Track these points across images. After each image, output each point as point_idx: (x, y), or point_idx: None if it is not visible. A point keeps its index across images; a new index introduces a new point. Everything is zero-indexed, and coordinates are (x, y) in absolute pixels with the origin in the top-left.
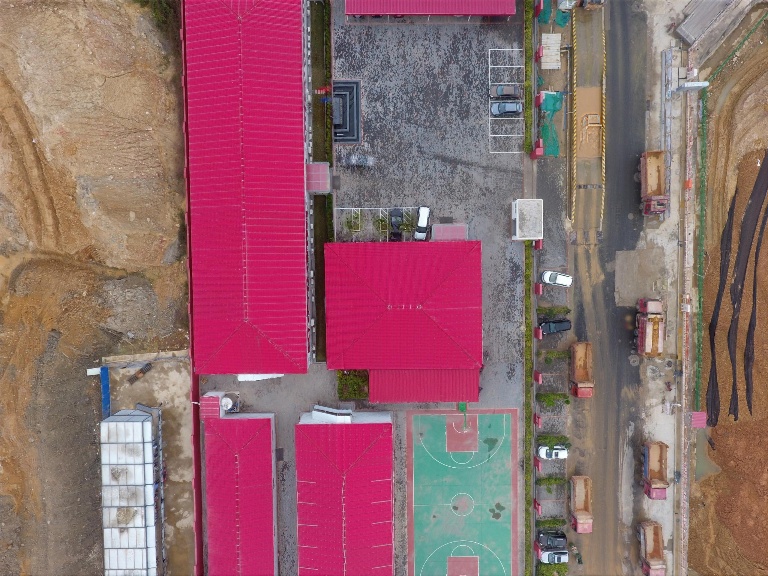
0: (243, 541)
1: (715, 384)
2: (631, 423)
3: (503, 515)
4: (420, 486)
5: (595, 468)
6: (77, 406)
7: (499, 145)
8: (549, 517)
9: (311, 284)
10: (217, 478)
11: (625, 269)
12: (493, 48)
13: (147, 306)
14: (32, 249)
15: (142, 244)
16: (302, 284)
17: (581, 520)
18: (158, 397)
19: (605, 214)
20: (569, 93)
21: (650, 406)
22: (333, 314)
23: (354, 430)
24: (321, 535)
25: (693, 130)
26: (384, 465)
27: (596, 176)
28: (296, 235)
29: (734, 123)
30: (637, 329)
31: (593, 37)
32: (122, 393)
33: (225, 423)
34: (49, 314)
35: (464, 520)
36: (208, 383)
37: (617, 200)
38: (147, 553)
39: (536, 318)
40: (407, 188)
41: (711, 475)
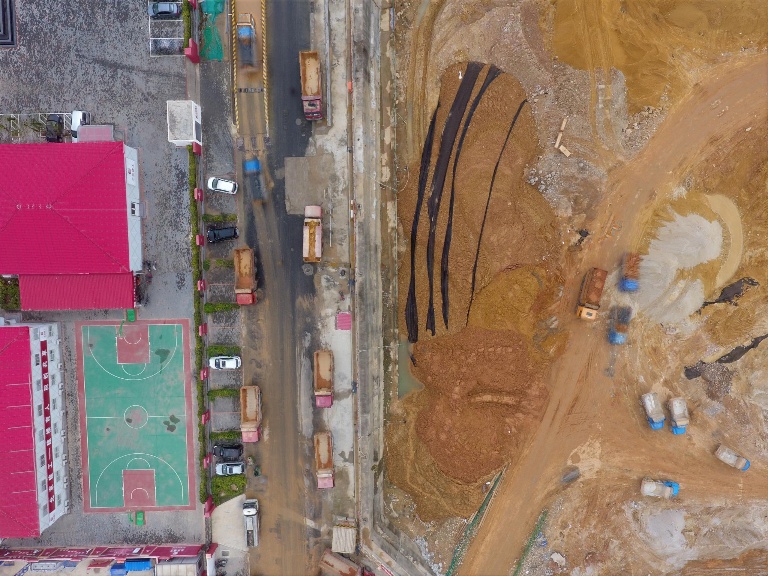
0: None
1: (413, 299)
2: (307, 334)
3: (178, 427)
4: (92, 398)
5: (272, 380)
6: None
7: (160, 48)
8: (227, 429)
9: None
10: None
11: (295, 176)
12: None
13: None
14: None
15: None
16: None
17: (244, 428)
18: None
19: (272, 119)
20: None
21: (326, 316)
22: None
23: None
24: None
25: (359, 33)
26: (21, 369)
27: (257, 79)
28: None
29: (432, 34)
30: None
31: None
32: None
33: None
34: None
35: (138, 433)
36: None
37: (284, 105)
38: None
39: (203, 226)
40: (67, 93)
41: (415, 392)
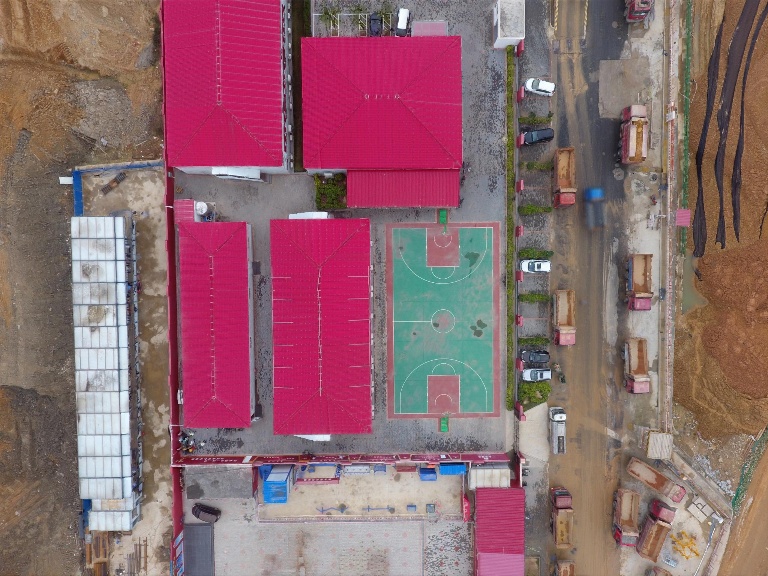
0: (218, 346)
1: (702, 212)
2: (615, 239)
3: (485, 332)
4: (400, 302)
5: (579, 286)
6: (49, 213)
7: None
8: (532, 336)
9: (289, 91)
10: (191, 282)
11: (609, 79)
12: None
13: (121, 110)
14: (3, 48)
15: (116, 45)
16: (277, 73)
17: (564, 330)
18: (132, 208)
19: (589, 22)
20: None
21: (635, 221)
22: (310, 110)
23: (331, 225)
24: (296, 332)
25: None
26: (361, 261)
27: None
28: (271, 21)
29: None
30: (621, 139)
31: None
32: (96, 204)
33: (200, 226)
34: (20, 111)
35: (445, 337)
36: (183, 194)
37: (601, 8)
38: (119, 353)
39: (518, 128)
40: None
41: (698, 307)
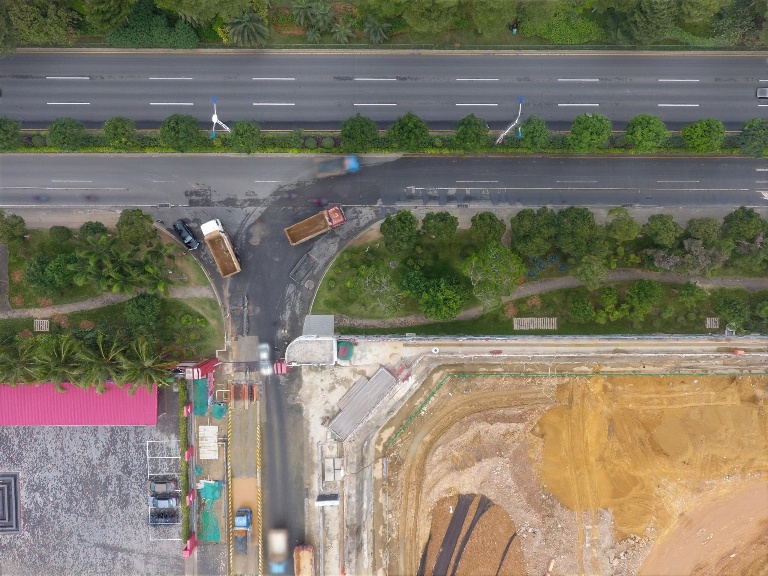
0: None
1: None
2: None
3: None
4: None
5: None
6: None
7: (159, 533)
8: None
9: None
10: None
11: None
12: (151, 440)
13: None
14: None
15: None
16: None
17: None
18: None
19: None
20: (226, 483)
21: None
22: None
23: None
24: None
25: (352, 517)
26: None
27: (253, 565)
28: None
29: (424, 474)
30: None
31: (248, 431)
32: None
33: None
34: None
35: None
36: None
37: None
38: None
39: None
40: (68, 575)
41: None
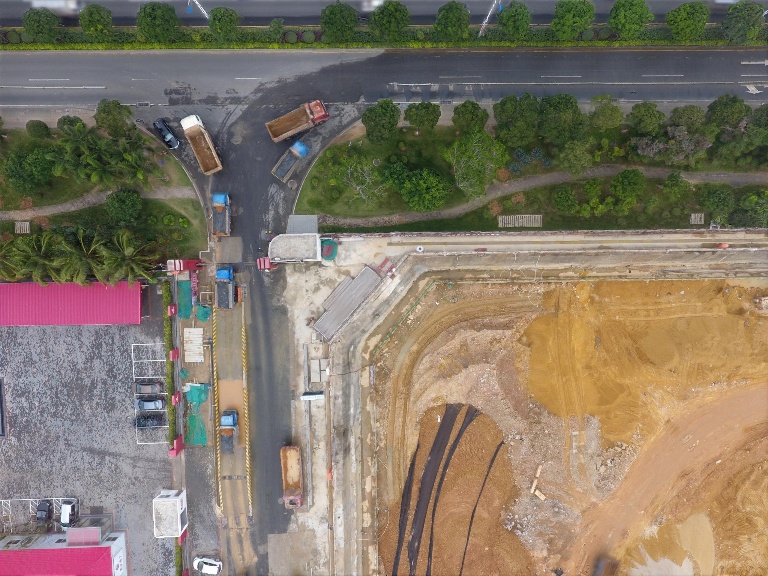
0: None
1: None
2: None
3: None
4: None
5: None
6: None
7: (146, 436)
8: None
9: None
10: None
11: (278, 551)
12: (135, 343)
13: None
14: None
15: None
16: None
17: None
18: None
19: (255, 500)
20: (212, 386)
21: None
22: None
23: None
24: None
25: (338, 418)
26: None
27: (241, 467)
28: None
29: (411, 383)
30: None
31: (233, 333)
32: None
33: None
34: None
35: None
36: None
37: (266, 486)
38: None
39: None
40: (56, 479)
41: None
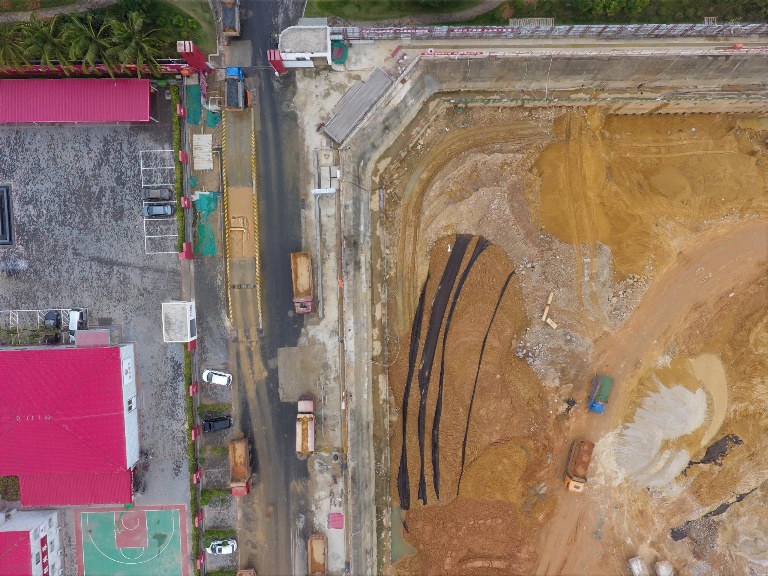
0: None
1: (405, 469)
2: (301, 515)
3: None
4: None
5: (268, 560)
6: None
7: (155, 246)
8: None
9: None
10: None
11: (288, 365)
12: (144, 150)
13: None
14: None
15: None
16: None
17: None
18: None
19: (265, 312)
20: (222, 193)
21: (319, 499)
22: None
23: None
24: None
25: (349, 228)
26: (22, 572)
27: (250, 276)
28: None
29: (421, 210)
30: None
31: (242, 138)
32: None
33: None
34: None
35: None
36: None
37: (276, 298)
38: None
39: (198, 416)
40: (64, 290)
41: (407, 557)
